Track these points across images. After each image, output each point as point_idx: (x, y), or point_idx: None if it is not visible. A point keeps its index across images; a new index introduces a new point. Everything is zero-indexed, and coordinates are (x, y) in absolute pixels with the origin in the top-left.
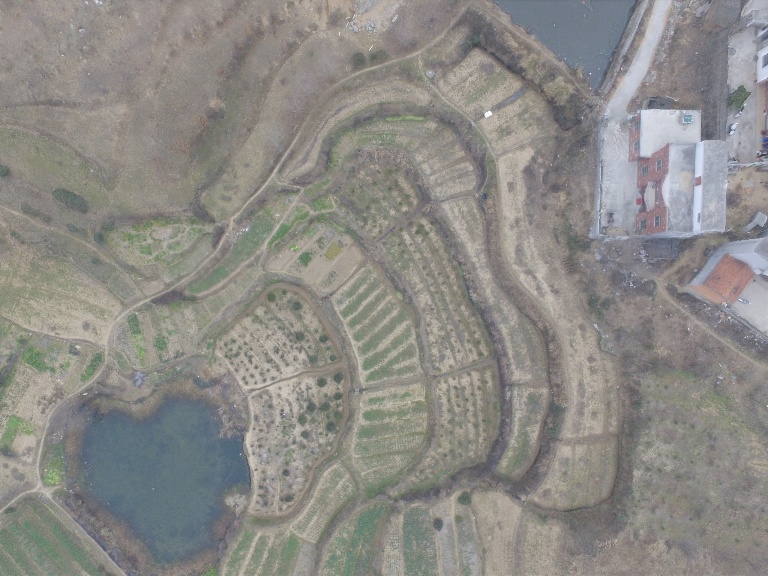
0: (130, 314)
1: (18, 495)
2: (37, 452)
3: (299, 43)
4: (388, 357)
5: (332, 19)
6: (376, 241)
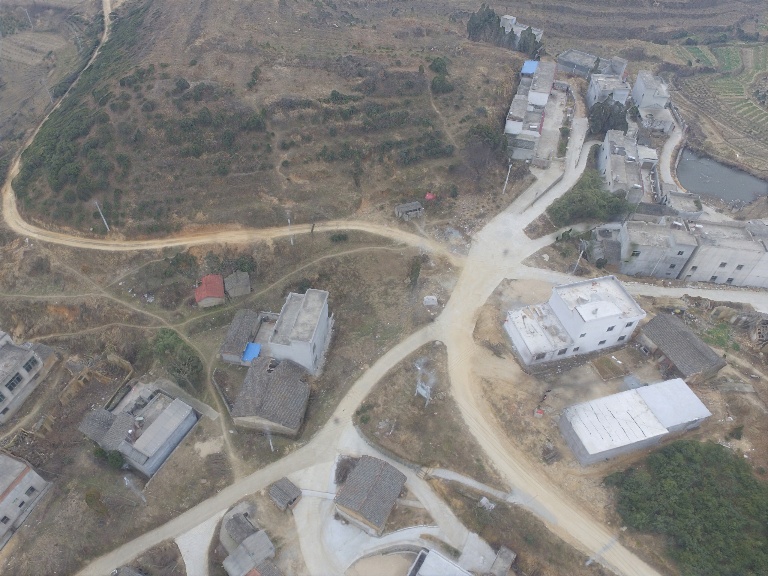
0: None
1: None
2: None
3: None
4: None
5: None
6: None
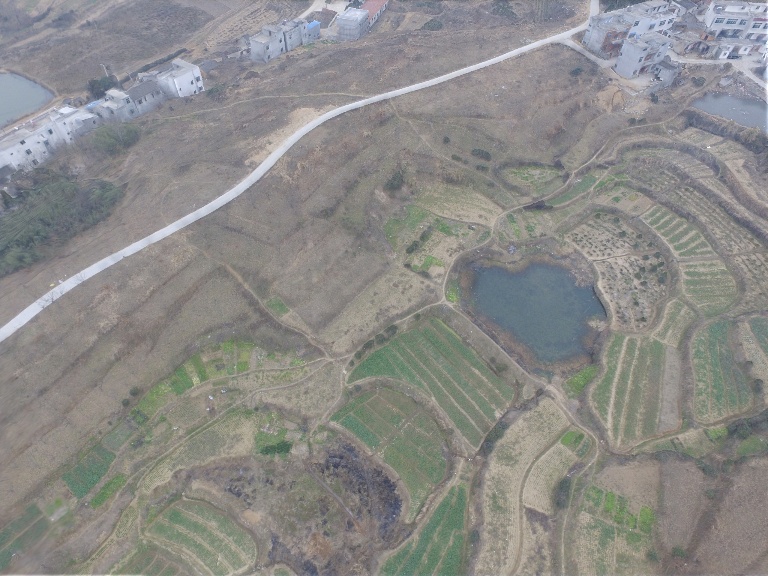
0: (508, 214)
1: (424, 307)
2: (444, 278)
3: (598, 116)
4: (689, 246)
5: (614, 108)
6: None
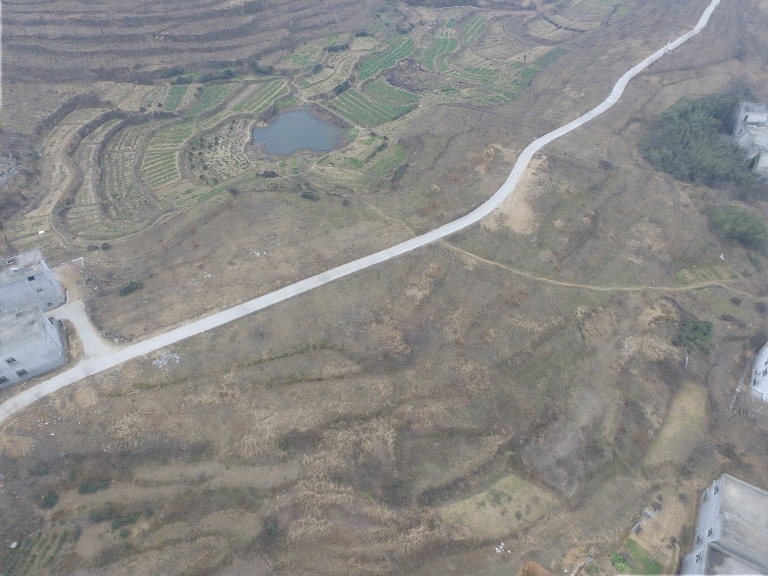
0: (297, 174)
1: None
2: None
3: None
4: None
5: None
6: None
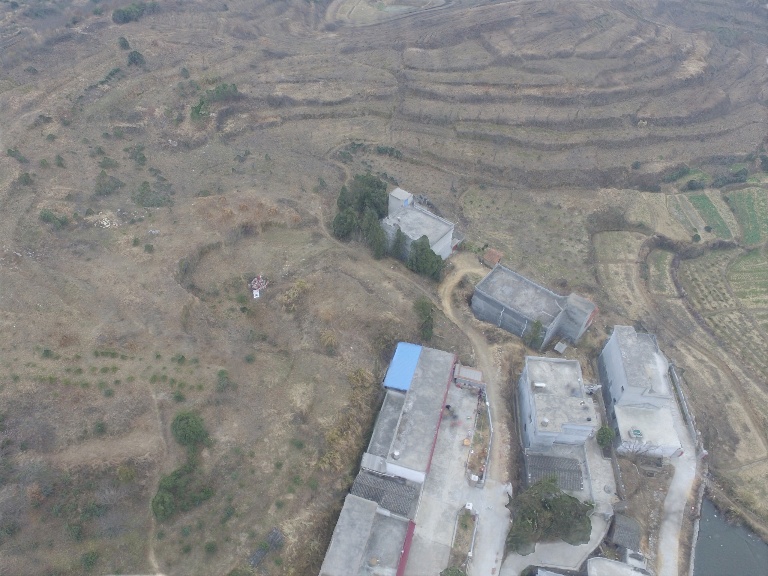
0: None
1: None
2: None
3: None
4: None
5: None
6: None
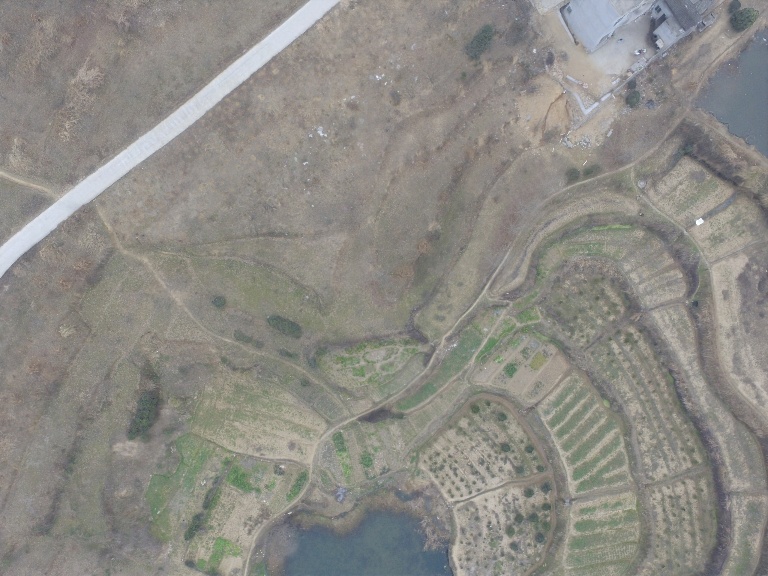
0: (335, 432)
1: None
2: (243, 573)
3: (511, 160)
4: (597, 466)
5: (547, 136)
6: (583, 350)
